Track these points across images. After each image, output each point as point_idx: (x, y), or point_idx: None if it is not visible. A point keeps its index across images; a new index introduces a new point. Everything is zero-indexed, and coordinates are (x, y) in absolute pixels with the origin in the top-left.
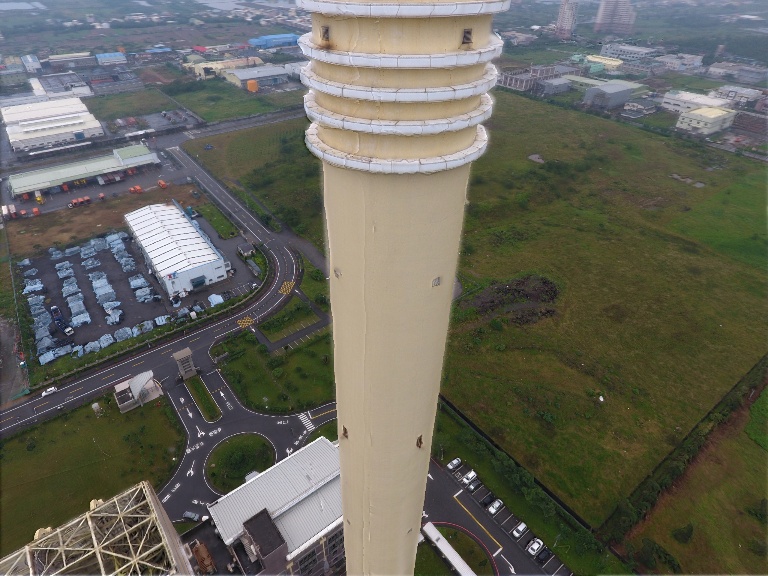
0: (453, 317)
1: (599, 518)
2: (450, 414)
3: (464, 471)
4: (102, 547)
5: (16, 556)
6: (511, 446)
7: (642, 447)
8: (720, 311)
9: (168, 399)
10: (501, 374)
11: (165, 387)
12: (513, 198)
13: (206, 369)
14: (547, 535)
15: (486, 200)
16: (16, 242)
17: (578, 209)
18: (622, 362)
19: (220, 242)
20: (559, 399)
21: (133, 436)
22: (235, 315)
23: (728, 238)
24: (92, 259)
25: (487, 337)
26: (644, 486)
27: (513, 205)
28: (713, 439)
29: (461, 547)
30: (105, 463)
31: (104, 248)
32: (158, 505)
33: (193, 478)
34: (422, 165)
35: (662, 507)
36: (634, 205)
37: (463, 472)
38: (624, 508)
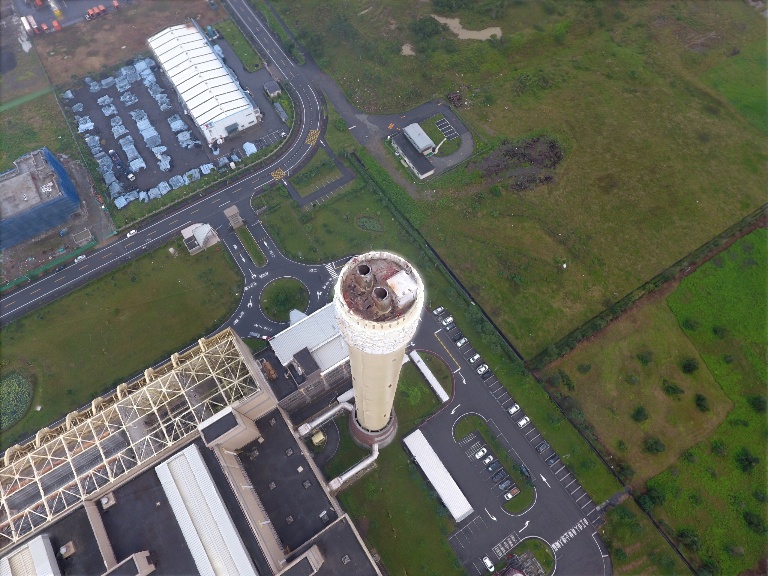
0: (460, 180)
1: (532, 354)
2: (442, 272)
3: (445, 316)
4: (216, 374)
5: (169, 375)
6: (483, 300)
7: (582, 307)
8: (705, 186)
9: (224, 245)
10: (490, 239)
11: (220, 234)
12: (550, 29)
13: (250, 220)
14: (492, 363)
15: (520, 31)
16: (51, 67)
17: (617, 46)
18: (594, 234)
19: (246, 76)
20: (530, 265)
21: (204, 275)
22: (268, 166)
23: (758, 97)
24: (129, 93)
25: (486, 202)
26: (572, 335)
27: (548, 39)
28: (639, 304)
29: (433, 366)
30: (189, 294)
31: (136, 79)
32: (239, 342)
33: (252, 309)
34: (384, 351)
35: (578, 350)
36: (680, 43)
37: (444, 317)
38: (550, 351)
